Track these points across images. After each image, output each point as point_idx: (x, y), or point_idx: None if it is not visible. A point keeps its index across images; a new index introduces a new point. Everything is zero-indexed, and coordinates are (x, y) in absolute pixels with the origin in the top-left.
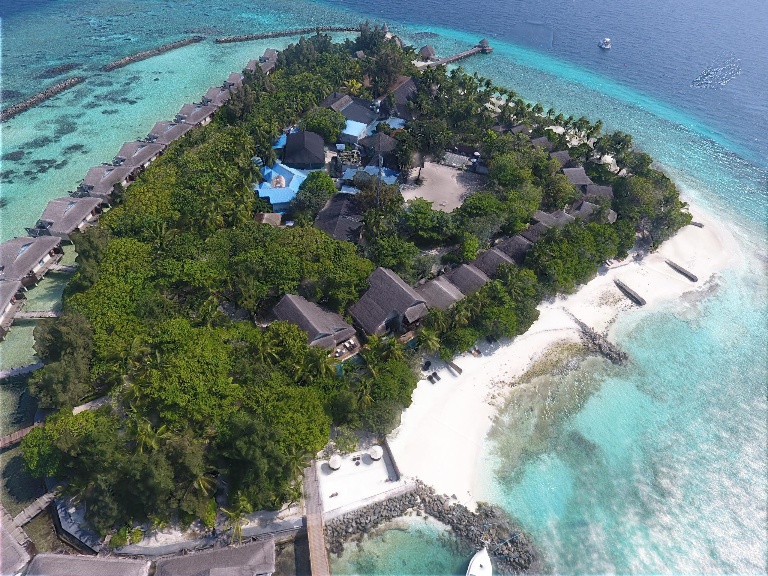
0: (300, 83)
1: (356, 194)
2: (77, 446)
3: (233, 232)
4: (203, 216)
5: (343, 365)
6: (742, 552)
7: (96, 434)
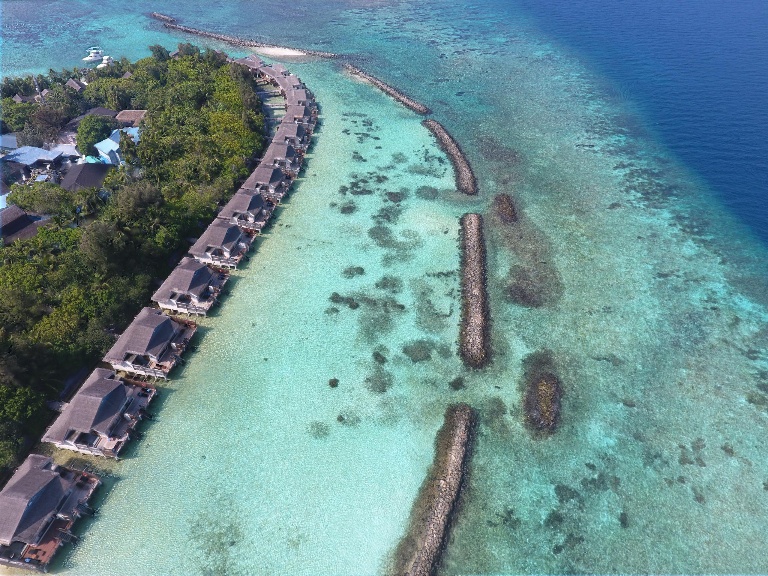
0: (32, 247)
1: (65, 116)
2: (218, 53)
3: (163, 94)
4: (181, 96)
5: (121, 65)
6: (6, 70)
7: (210, 50)
